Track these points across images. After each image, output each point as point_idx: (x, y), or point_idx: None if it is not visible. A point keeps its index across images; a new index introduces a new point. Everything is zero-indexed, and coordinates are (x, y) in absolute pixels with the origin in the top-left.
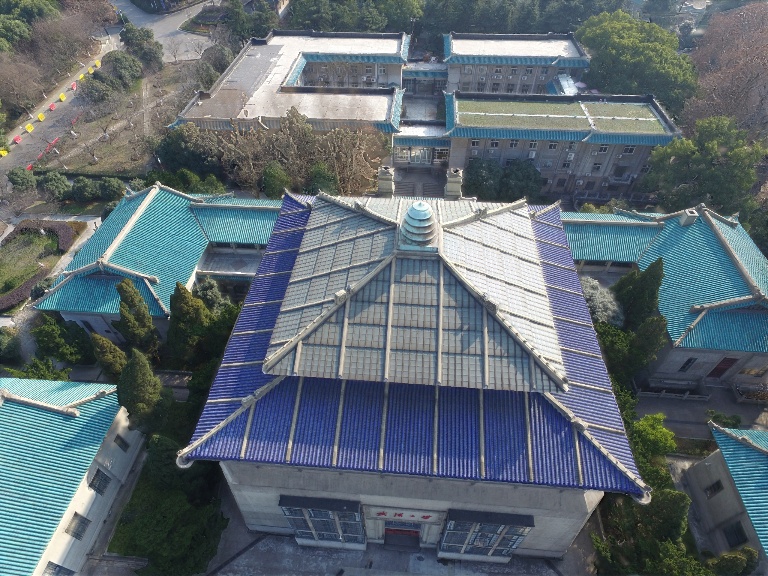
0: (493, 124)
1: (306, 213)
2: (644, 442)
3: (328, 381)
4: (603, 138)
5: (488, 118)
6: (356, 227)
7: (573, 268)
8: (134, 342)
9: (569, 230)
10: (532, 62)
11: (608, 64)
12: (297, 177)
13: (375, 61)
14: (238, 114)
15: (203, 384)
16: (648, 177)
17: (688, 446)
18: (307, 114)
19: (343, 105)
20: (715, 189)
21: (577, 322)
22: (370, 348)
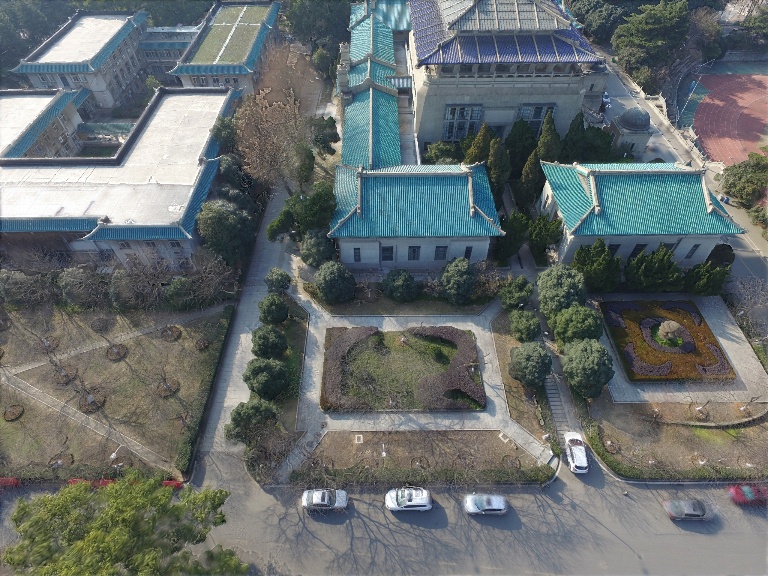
0: (237, 55)
1: (443, 49)
2: None
3: (556, 31)
4: (269, 22)
5: (227, 56)
6: (486, 5)
7: None
8: (503, 186)
9: (376, 37)
10: (125, 33)
11: (167, 1)
12: (299, 143)
13: (58, 111)
14: (174, 185)
15: (532, 130)
16: (309, 21)
17: None
18: (192, 137)
19: (179, 118)
20: (337, 0)
21: None
22: (549, 7)
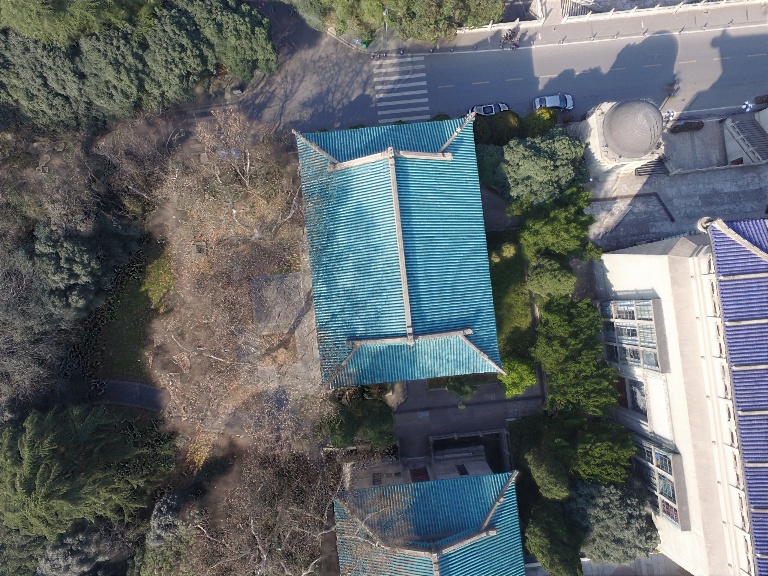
0: None
1: None
2: (527, 363)
3: None
4: None
5: None
6: None
7: (756, 514)
8: None
9: None
10: None
11: None
12: None
13: None
14: None
15: None
16: None
17: (468, 376)
18: None
19: None
20: None
21: (766, 411)
22: None
